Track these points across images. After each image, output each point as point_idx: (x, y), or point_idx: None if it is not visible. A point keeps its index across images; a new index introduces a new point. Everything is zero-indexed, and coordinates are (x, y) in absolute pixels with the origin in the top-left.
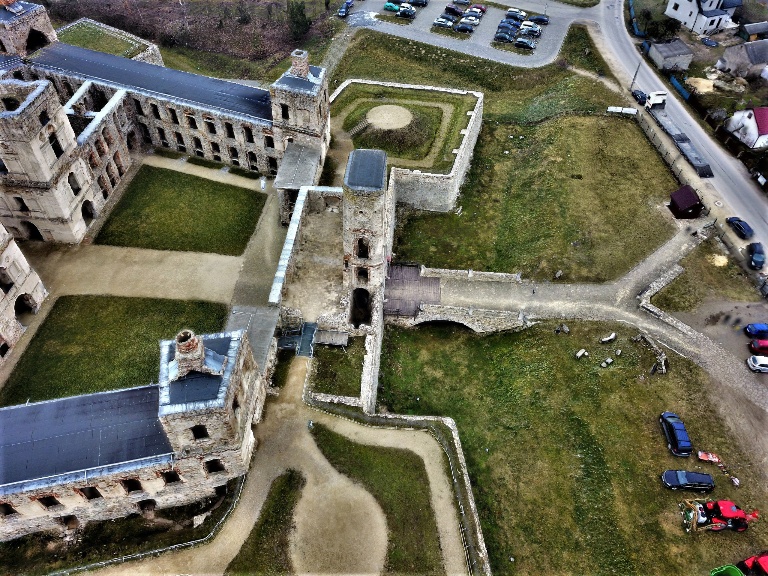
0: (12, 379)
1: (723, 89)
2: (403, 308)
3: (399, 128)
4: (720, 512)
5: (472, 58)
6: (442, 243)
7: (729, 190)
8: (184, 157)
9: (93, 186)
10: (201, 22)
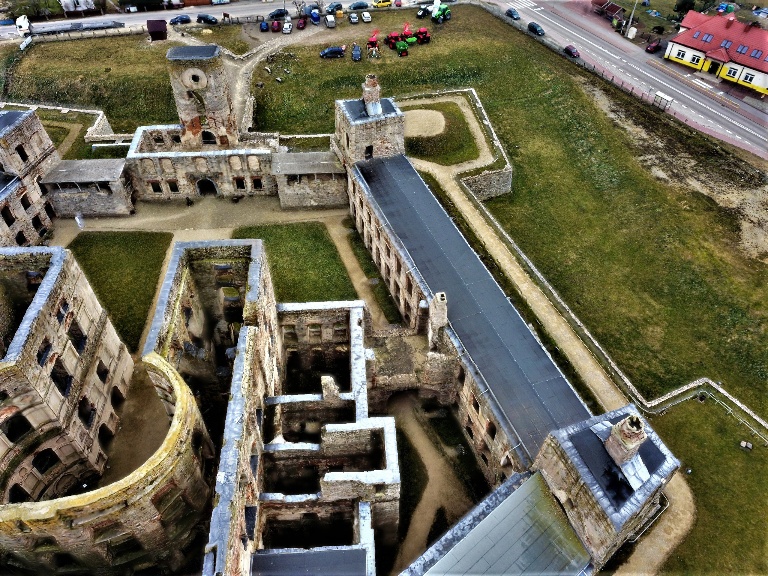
0: None
1: (5, 9)
2: None
3: None
4: (374, 43)
5: None
6: None
7: (140, 21)
8: None
9: None
10: None
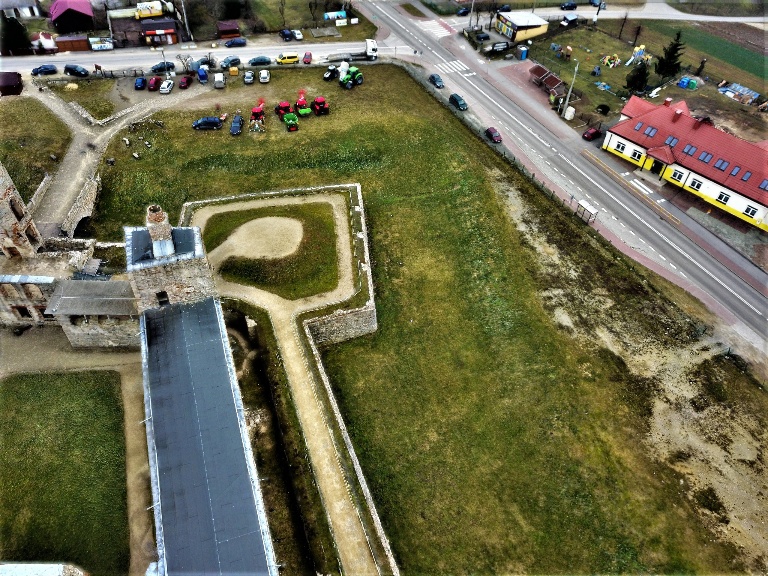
0: None
1: None
2: None
3: None
4: (258, 114)
5: None
6: None
7: None
8: None
9: None
10: None
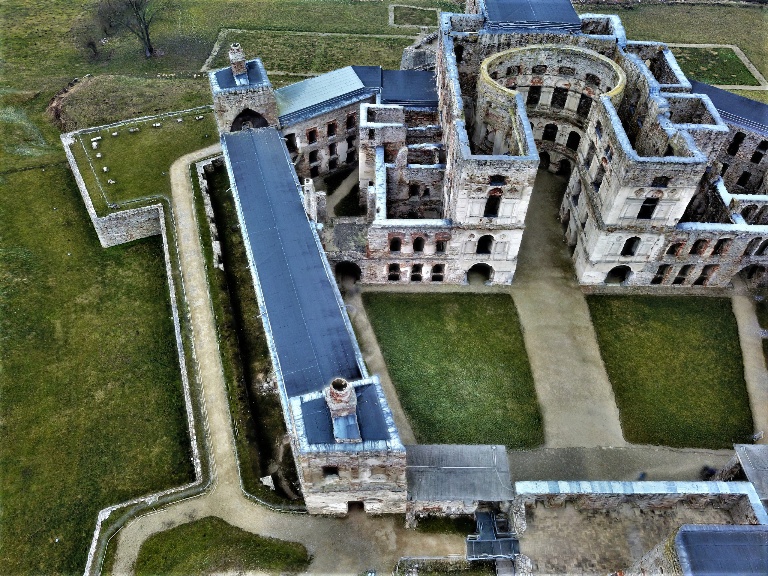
0: (414, 295)
1: None
2: None
3: None
4: None
5: None
6: None
7: None
8: None
9: (650, 264)
10: None
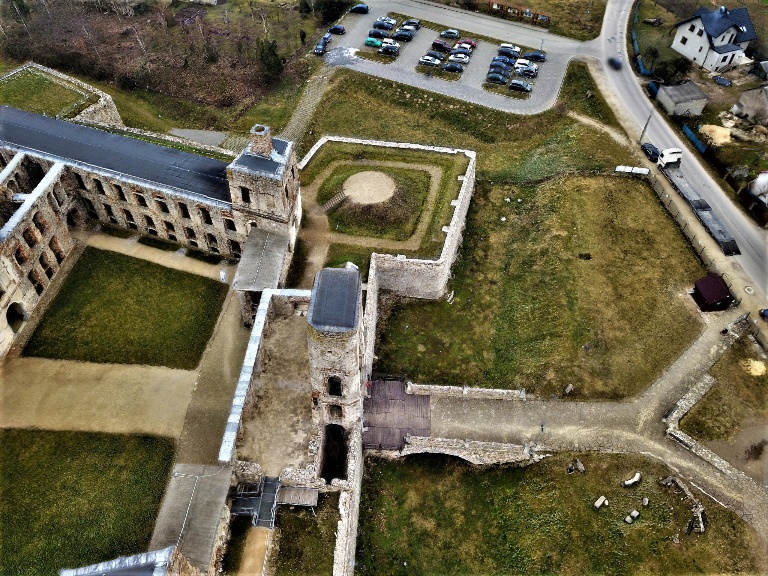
0: None
1: (742, 139)
2: (386, 439)
3: (380, 202)
4: None
5: (462, 103)
6: (432, 341)
7: (759, 271)
8: (135, 236)
9: (22, 284)
10: (165, 60)
